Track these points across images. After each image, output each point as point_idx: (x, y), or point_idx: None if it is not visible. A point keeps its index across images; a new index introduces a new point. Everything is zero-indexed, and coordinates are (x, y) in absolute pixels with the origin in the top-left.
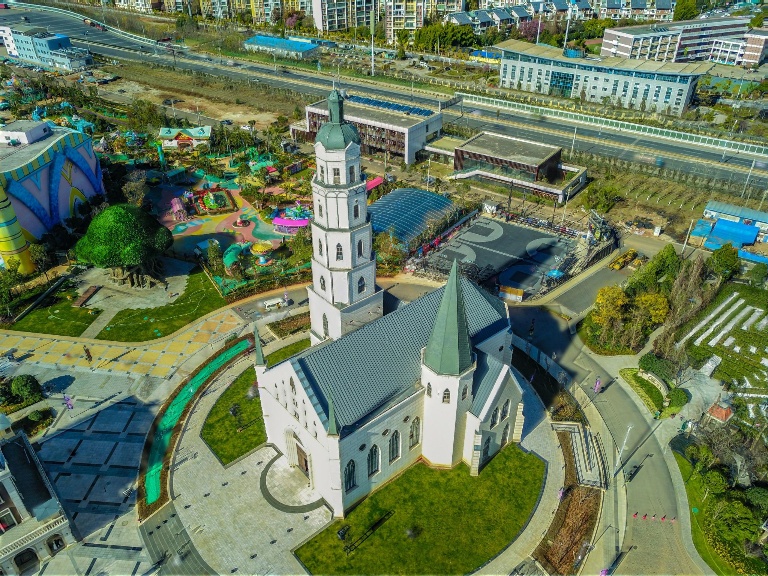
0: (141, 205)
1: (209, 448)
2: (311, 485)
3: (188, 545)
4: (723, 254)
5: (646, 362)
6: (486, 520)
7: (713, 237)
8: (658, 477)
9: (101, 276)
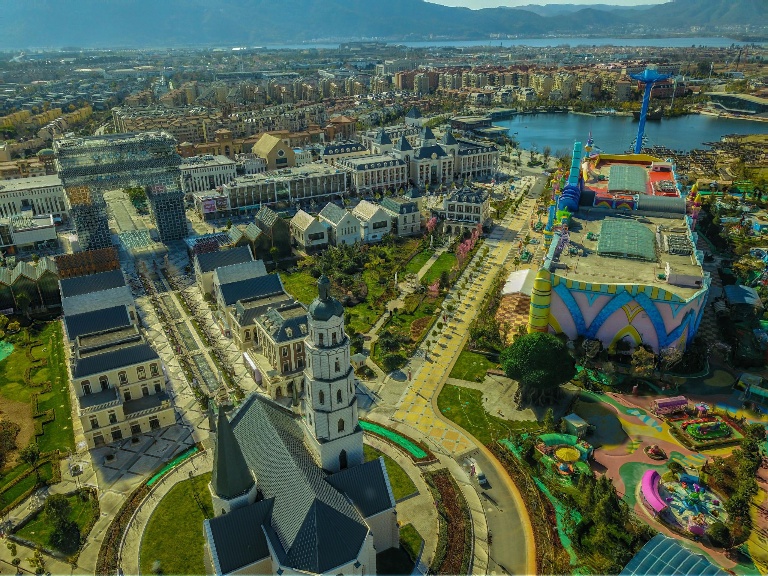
0: (639, 372)
1: None
2: None
3: None
4: None
5: None
6: (168, 573)
7: None
8: None
9: None
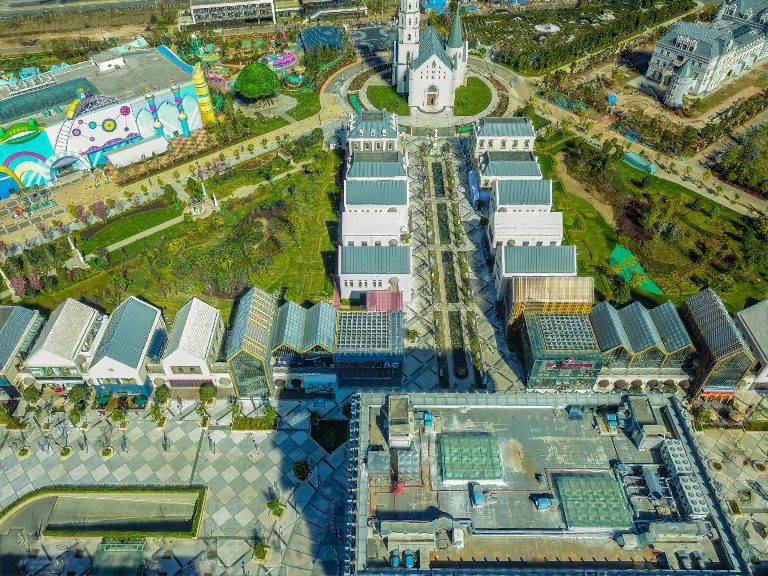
0: None
1: (398, 115)
2: (438, 104)
3: (431, 128)
4: (454, 6)
5: (468, 45)
6: None
7: (432, 7)
8: (498, 69)
9: (246, 110)
